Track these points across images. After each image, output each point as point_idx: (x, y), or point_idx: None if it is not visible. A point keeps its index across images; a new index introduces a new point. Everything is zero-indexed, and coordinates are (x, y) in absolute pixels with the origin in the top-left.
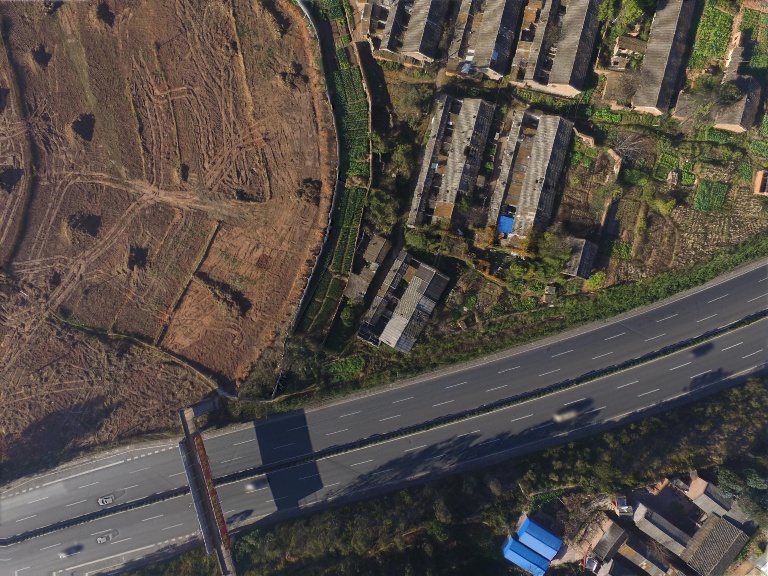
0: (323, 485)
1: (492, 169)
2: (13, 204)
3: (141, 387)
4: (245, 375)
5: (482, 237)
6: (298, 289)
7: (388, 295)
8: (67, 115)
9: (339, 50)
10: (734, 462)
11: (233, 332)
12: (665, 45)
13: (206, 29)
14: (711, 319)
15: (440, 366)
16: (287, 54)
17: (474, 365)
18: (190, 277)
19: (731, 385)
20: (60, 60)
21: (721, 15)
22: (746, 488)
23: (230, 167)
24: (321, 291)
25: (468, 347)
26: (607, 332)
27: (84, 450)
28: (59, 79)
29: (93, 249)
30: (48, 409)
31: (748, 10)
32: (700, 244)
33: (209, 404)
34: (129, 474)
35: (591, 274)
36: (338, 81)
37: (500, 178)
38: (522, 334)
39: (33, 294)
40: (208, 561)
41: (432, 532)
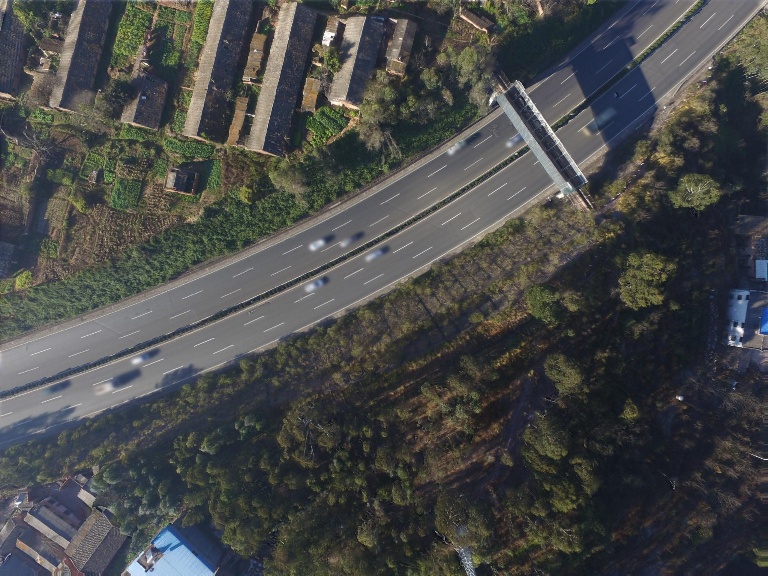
0: None
1: None
2: None
3: None
4: None
5: None
6: None
7: None
8: None
9: None
10: None
11: None
12: (72, 45)
13: None
14: (184, 315)
15: None
16: None
17: None
18: None
19: None
20: None
21: (141, 14)
22: None
23: None
24: None
25: None
26: (84, 330)
27: None
28: None
29: None
30: None
31: (162, 8)
32: (114, 242)
33: None
34: None
35: (20, 273)
36: None
37: None
38: None
39: None
40: None
41: None
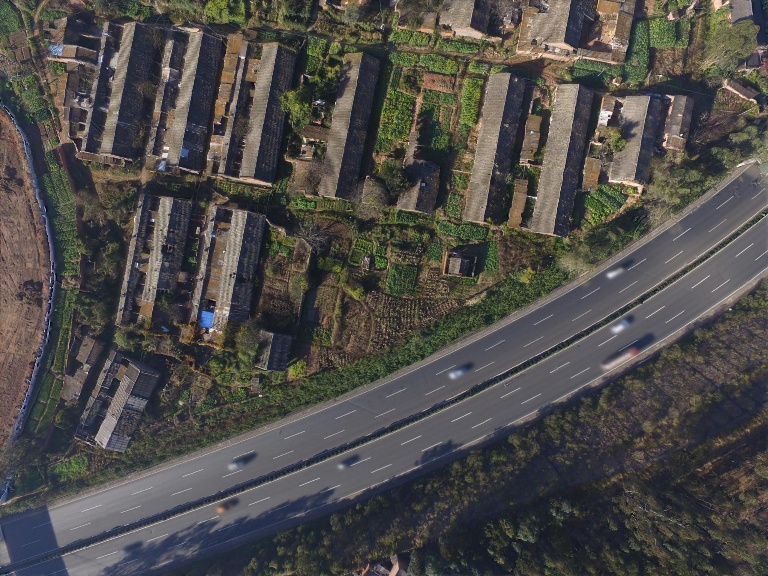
0: None
1: (196, 263)
2: None
3: None
4: None
5: (186, 333)
6: (23, 392)
7: (102, 395)
8: None
9: (47, 153)
10: (433, 544)
11: None
12: (342, 134)
13: None
14: (439, 391)
15: None
16: (1, 159)
17: (209, 452)
18: None
19: (460, 456)
20: None
21: (404, 97)
22: None
23: None
24: (45, 392)
25: (190, 439)
26: (337, 411)
27: None
28: None
29: None
30: None
31: (427, 91)
32: (393, 328)
33: None
34: None
35: (293, 363)
36: (48, 184)
37: (199, 273)
38: (242, 422)
39: None
40: None
41: None
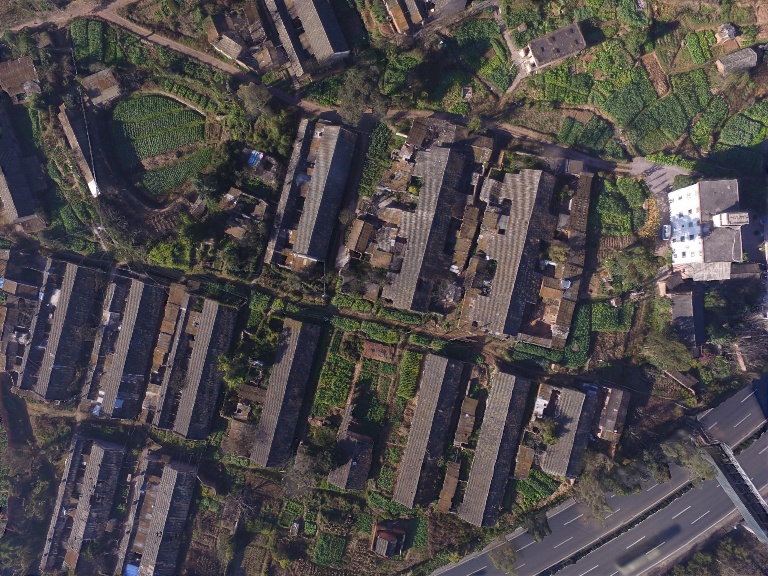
0: None
1: (125, 510)
2: None
3: None
4: None
5: None
6: None
7: None
8: None
9: None
10: None
11: None
12: (277, 403)
13: None
14: None
15: None
16: None
17: None
18: None
19: None
20: None
21: (343, 363)
22: None
23: None
24: None
25: None
26: None
27: None
28: None
29: None
30: None
31: (366, 360)
32: None
33: None
34: None
35: None
36: None
37: (127, 525)
38: None
39: None
40: None
41: None
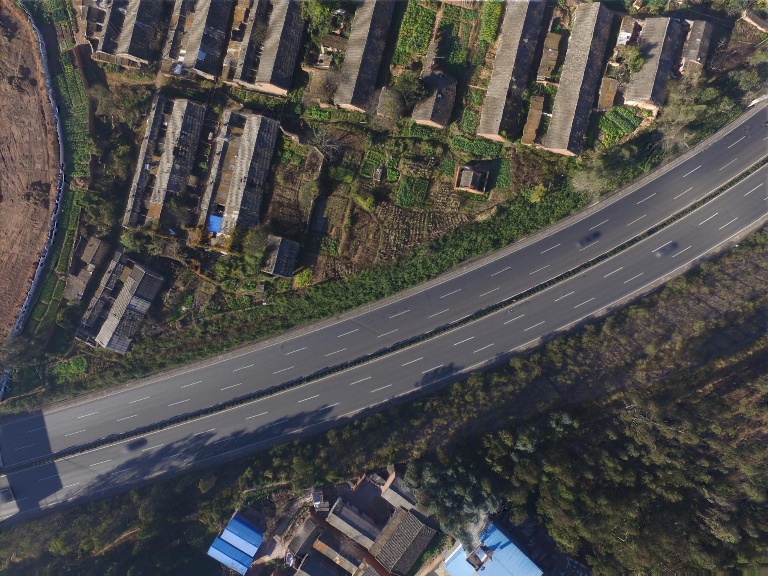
0: (63, 486)
1: (207, 169)
2: None
3: None
4: None
5: (193, 237)
6: (25, 291)
7: (105, 296)
8: None
9: (62, 53)
10: (430, 456)
11: None
12: (361, 42)
13: None
14: (443, 314)
15: (169, 365)
16: (15, 58)
17: (209, 364)
18: None
19: (460, 379)
20: None
21: (424, 11)
22: (424, 482)
23: None
24: (47, 293)
25: (191, 346)
26: (340, 329)
27: None
28: None
29: None
30: None
31: (448, 6)
32: (402, 240)
33: None
34: None
35: (299, 272)
36: (62, 84)
37: (210, 178)
38: (245, 332)
39: None
40: None
41: None
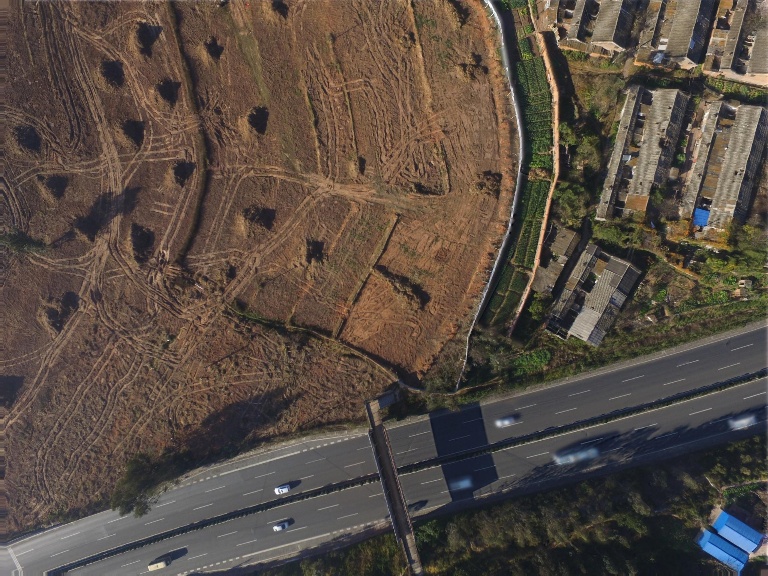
0: (498, 477)
1: (684, 161)
2: (186, 198)
3: (320, 379)
4: (427, 368)
5: (675, 230)
6: (480, 282)
7: (577, 288)
8: (240, 108)
9: (522, 40)
10: None
11: (412, 325)
12: None
13: (383, 20)
14: None
15: (622, 359)
16: (466, 45)
17: (652, 358)
18: (369, 270)
19: None
20: (232, 53)
21: None
22: None
23: (407, 160)
24: (504, 284)
25: (653, 341)
26: None
27: (265, 441)
28: (231, 72)
29: (268, 242)
30: (227, 400)
31: None
32: None
33: (391, 396)
34: (305, 464)
35: None
36: (521, 72)
37: (695, 170)
38: (708, 328)
39: (208, 287)
40: (387, 550)
41: (624, 524)
